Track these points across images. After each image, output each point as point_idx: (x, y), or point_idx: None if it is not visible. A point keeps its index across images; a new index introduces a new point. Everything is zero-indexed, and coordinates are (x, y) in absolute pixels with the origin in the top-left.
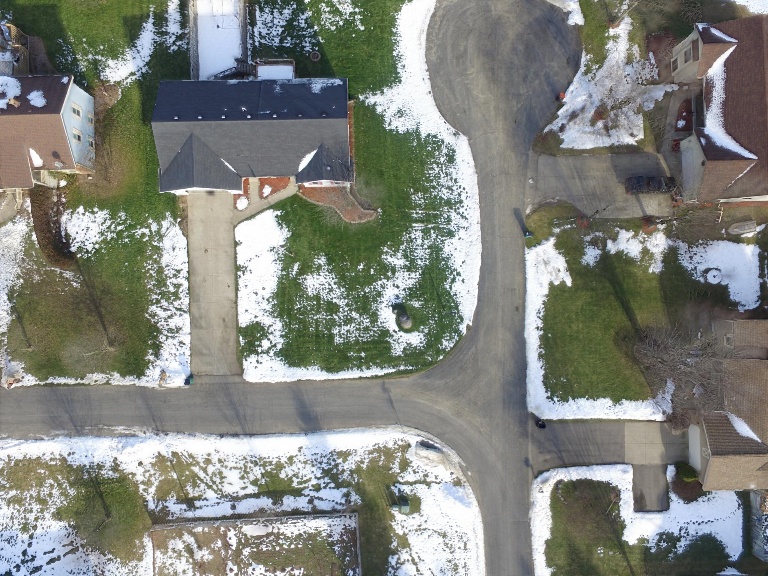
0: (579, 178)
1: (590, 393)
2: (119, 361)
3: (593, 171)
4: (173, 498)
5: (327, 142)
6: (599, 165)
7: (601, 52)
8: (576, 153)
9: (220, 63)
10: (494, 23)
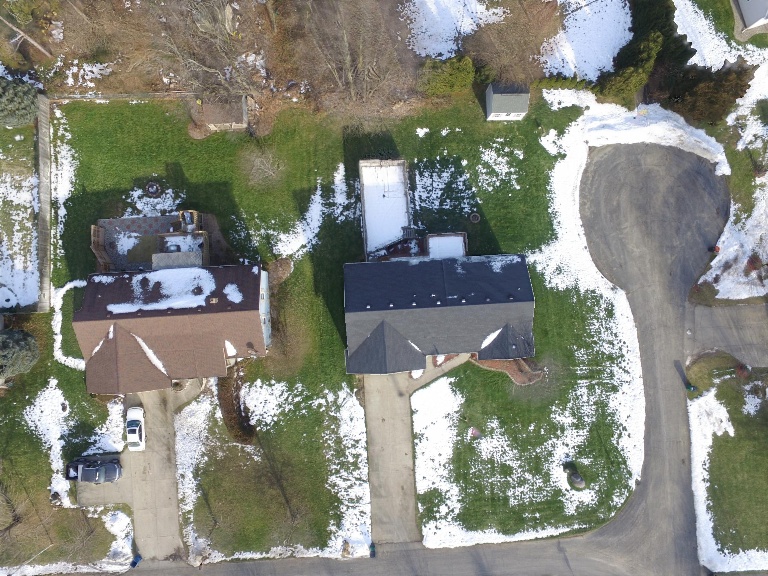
0: (736, 328)
1: (760, 544)
2: (302, 533)
3: (749, 321)
4: None
5: (512, 322)
6: (754, 314)
7: (749, 201)
8: (731, 303)
9: (387, 232)
10: (644, 177)
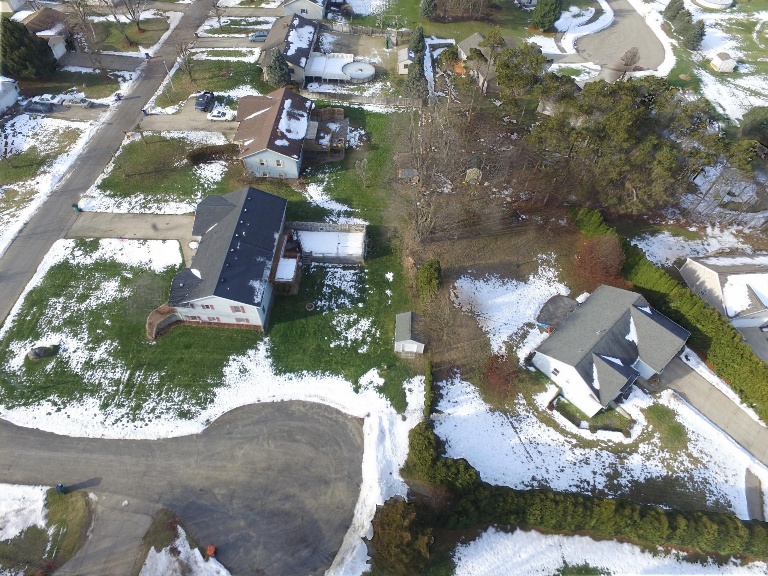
0: (103, 570)
1: None
2: (114, 178)
3: None
4: (1, 197)
5: (203, 284)
6: None
7: None
8: (136, 568)
9: (311, 243)
10: (321, 475)
